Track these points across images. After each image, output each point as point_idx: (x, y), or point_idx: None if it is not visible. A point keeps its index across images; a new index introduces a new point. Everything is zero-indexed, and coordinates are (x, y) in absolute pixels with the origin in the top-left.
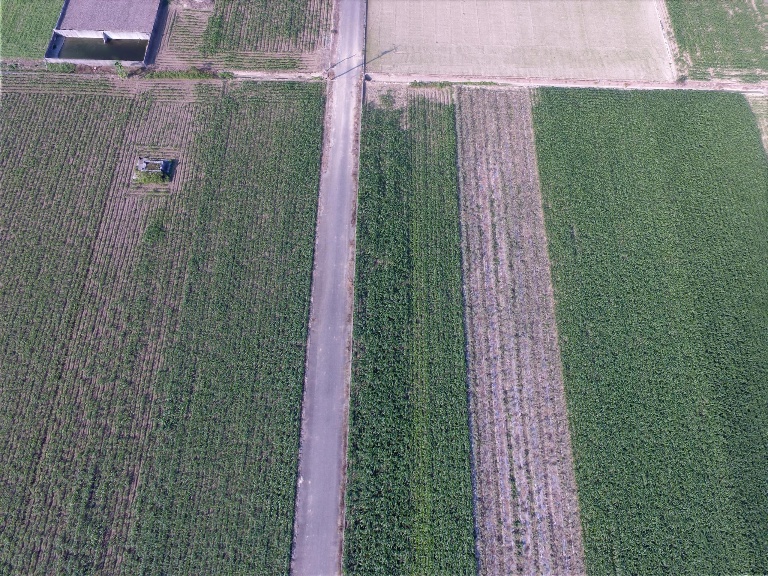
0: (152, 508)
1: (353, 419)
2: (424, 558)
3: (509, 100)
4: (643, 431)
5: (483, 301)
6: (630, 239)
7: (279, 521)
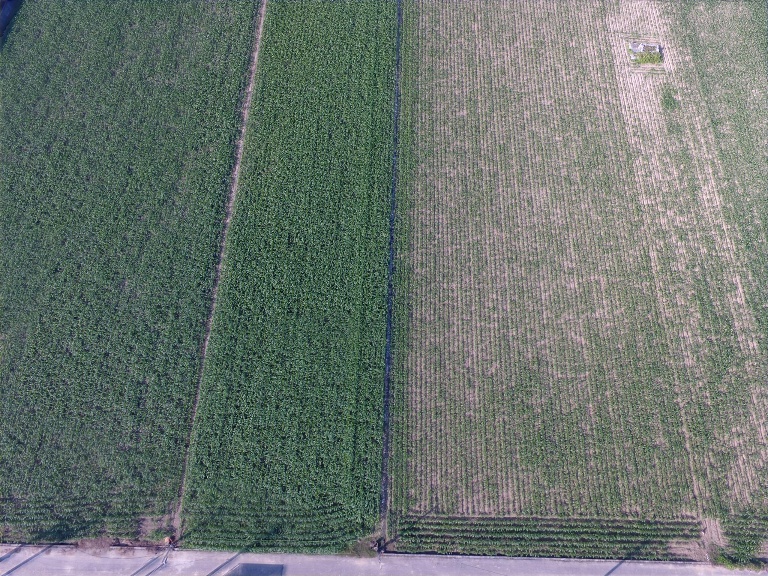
0: None
1: None
2: None
3: None
4: None
5: None
6: None
7: None
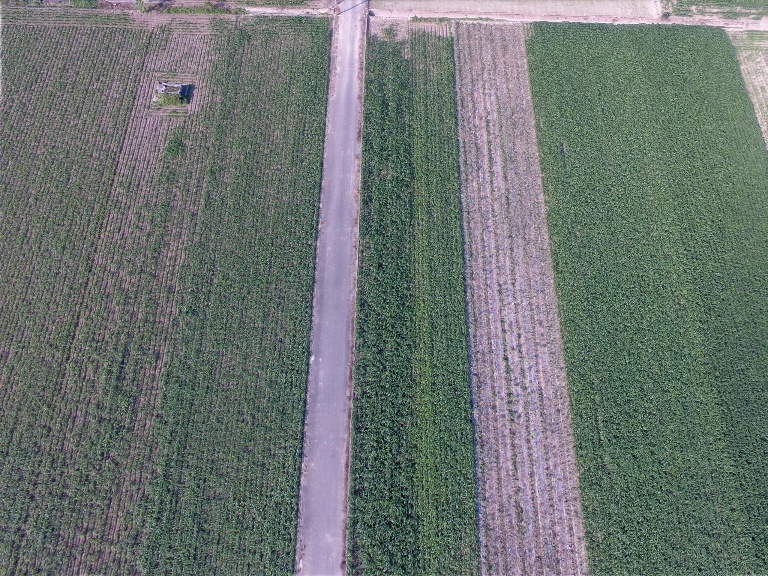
0: (177, 381)
1: (360, 306)
2: (425, 422)
3: (504, 33)
4: (626, 317)
5: (479, 207)
6: (616, 154)
7: (293, 392)
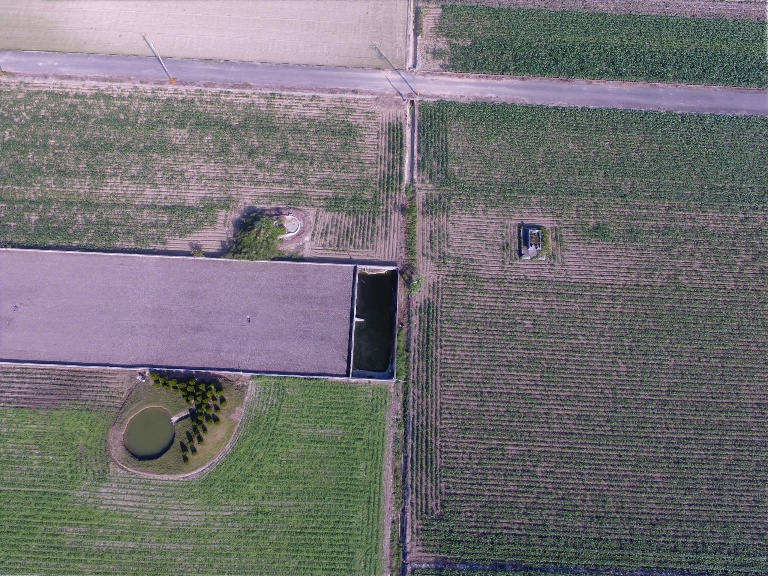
0: None
1: (729, 81)
2: None
3: None
4: None
5: (625, 3)
6: None
7: None
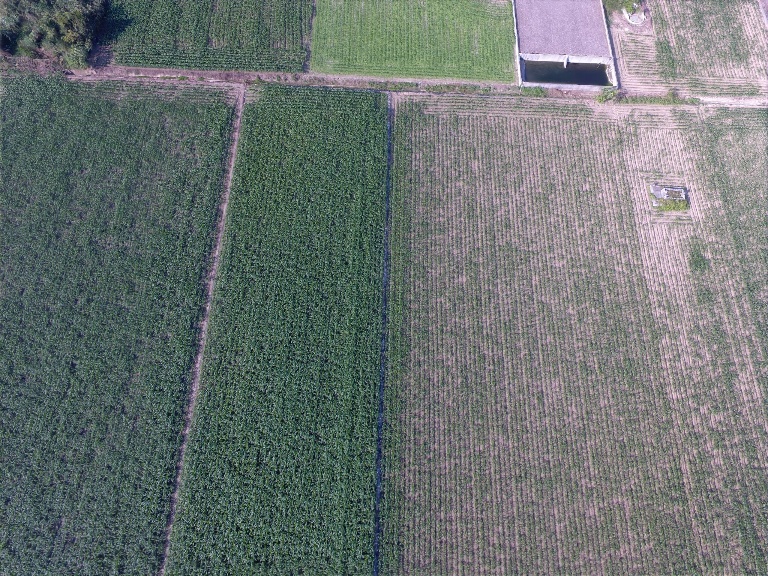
0: None
1: None
2: None
3: None
4: None
5: None
6: None
7: None
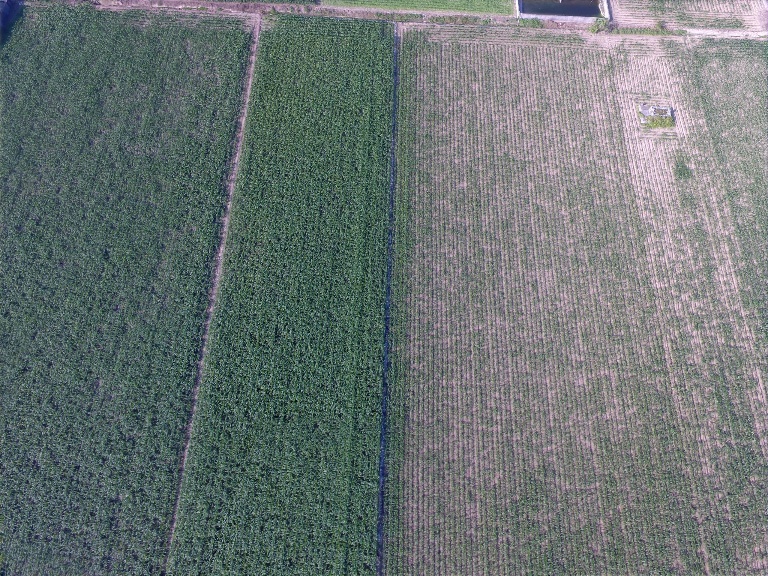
0: None
1: None
2: None
3: None
4: None
5: None
6: None
7: None
